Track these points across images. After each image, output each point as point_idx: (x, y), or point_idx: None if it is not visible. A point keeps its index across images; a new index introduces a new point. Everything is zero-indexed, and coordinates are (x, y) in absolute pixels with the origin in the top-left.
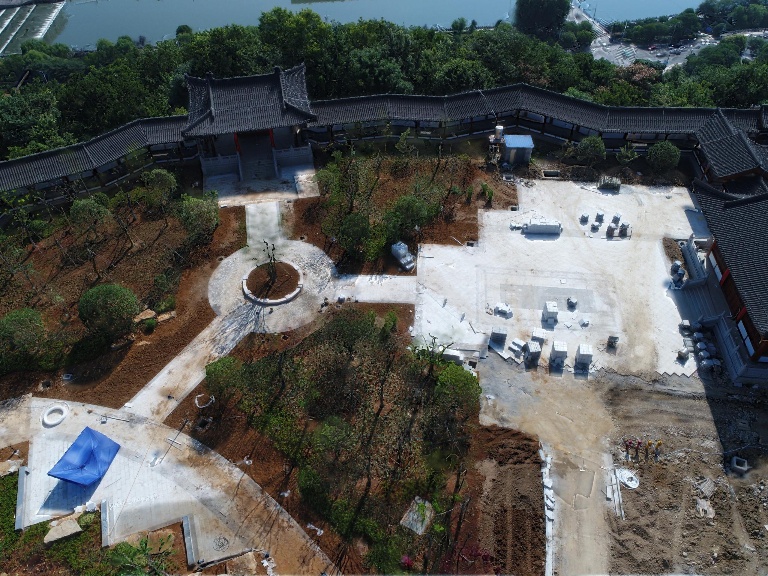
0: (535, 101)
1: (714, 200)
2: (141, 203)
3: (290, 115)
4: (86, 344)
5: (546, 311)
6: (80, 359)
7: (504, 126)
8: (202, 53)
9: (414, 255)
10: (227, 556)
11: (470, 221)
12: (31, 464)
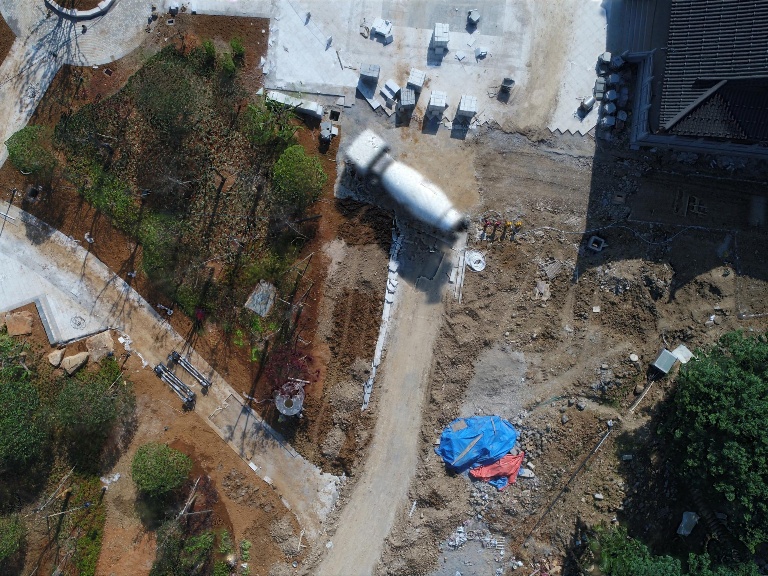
0: None
1: None
2: None
3: None
4: None
5: (434, 38)
6: None
7: None
8: None
9: None
10: (85, 334)
11: None
12: None
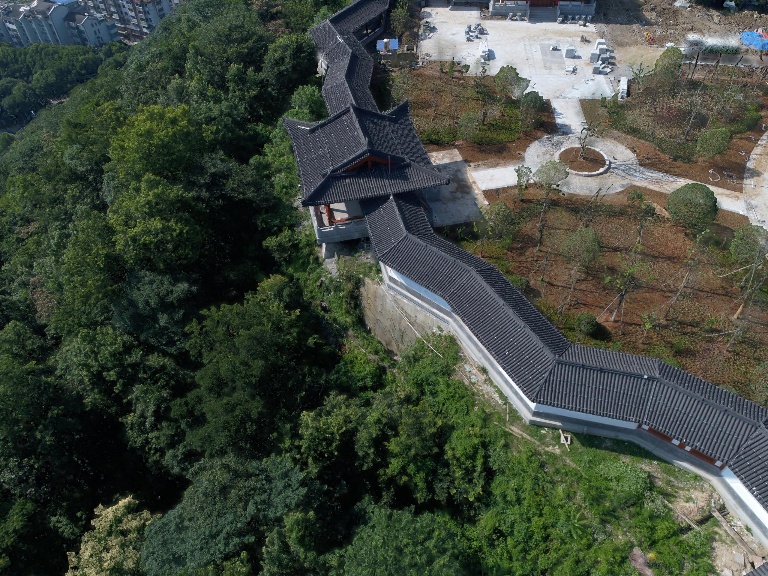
0: (347, 23)
1: None
2: None
3: (399, 119)
4: (712, 240)
5: (572, 52)
6: (725, 243)
7: None
8: None
9: None
10: None
11: None
12: None
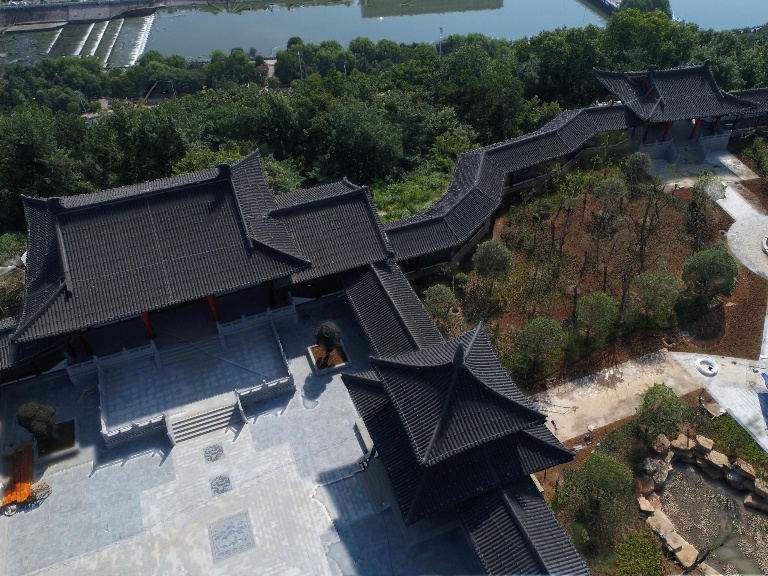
0: None
1: None
2: None
3: (728, 104)
4: (686, 305)
5: None
6: (689, 318)
7: None
8: (562, 51)
9: None
10: None
11: None
12: (725, 407)
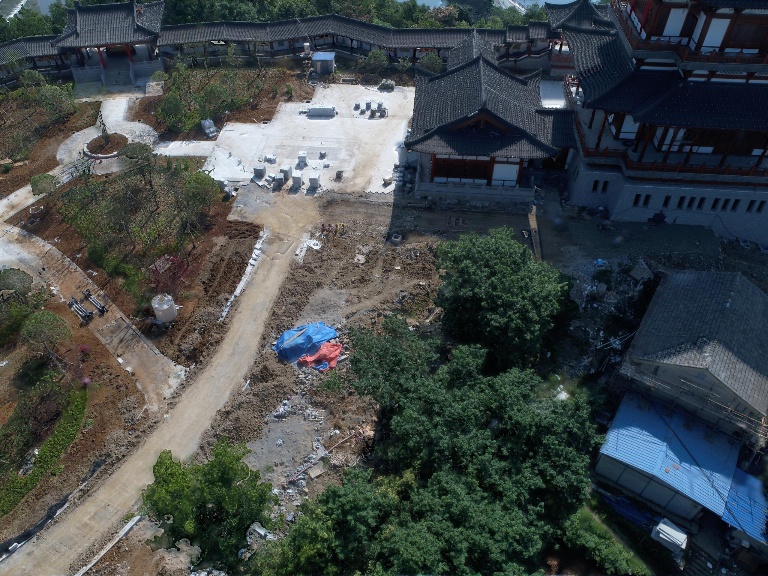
0: (341, 27)
1: (425, 78)
2: (20, 98)
3: (140, 33)
4: None
5: (298, 157)
6: None
7: (323, 49)
8: None
9: (219, 129)
10: None
11: (270, 109)
12: None
